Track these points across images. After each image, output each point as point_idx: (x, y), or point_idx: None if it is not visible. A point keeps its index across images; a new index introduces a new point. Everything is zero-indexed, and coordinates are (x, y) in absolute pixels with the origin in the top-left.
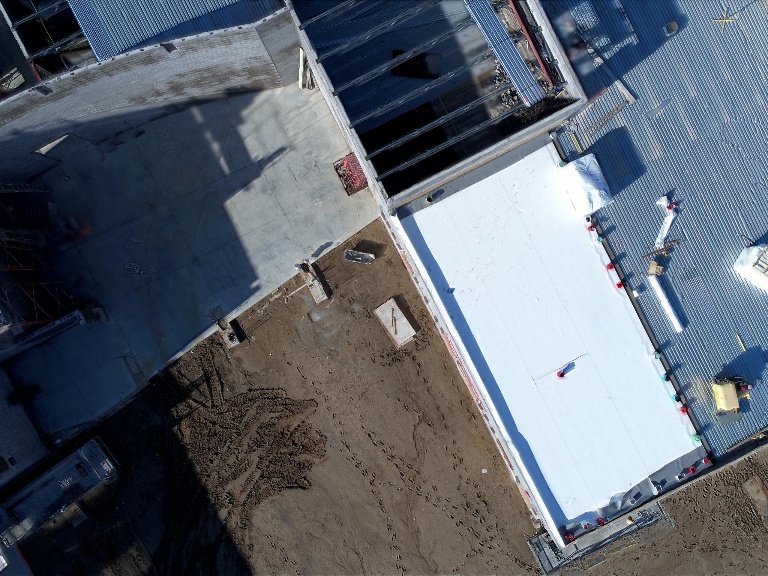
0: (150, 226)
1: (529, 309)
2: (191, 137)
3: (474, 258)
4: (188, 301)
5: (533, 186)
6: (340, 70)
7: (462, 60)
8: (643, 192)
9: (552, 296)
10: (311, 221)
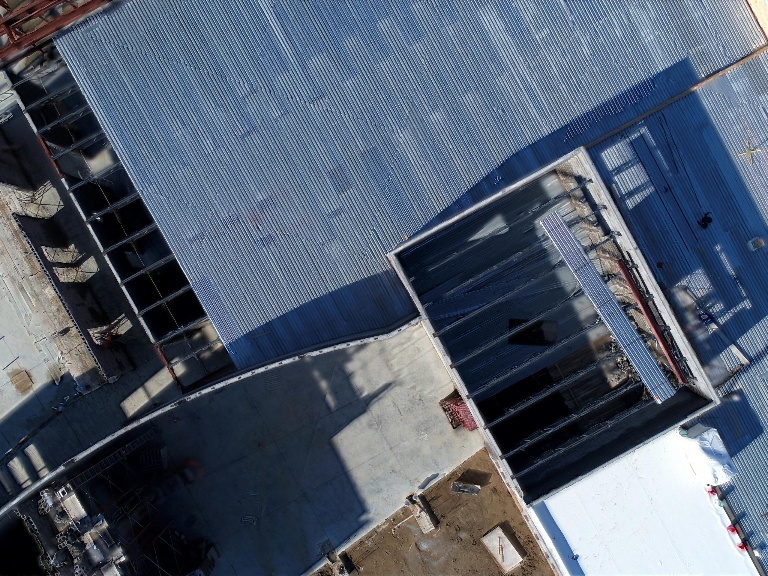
0: (258, 463)
1: (652, 572)
2: (297, 376)
3: (597, 525)
4: (297, 536)
5: (653, 452)
6: (458, 340)
7: (577, 326)
8: (760, 452)
9: (674, 559)
10: (417, 454)
